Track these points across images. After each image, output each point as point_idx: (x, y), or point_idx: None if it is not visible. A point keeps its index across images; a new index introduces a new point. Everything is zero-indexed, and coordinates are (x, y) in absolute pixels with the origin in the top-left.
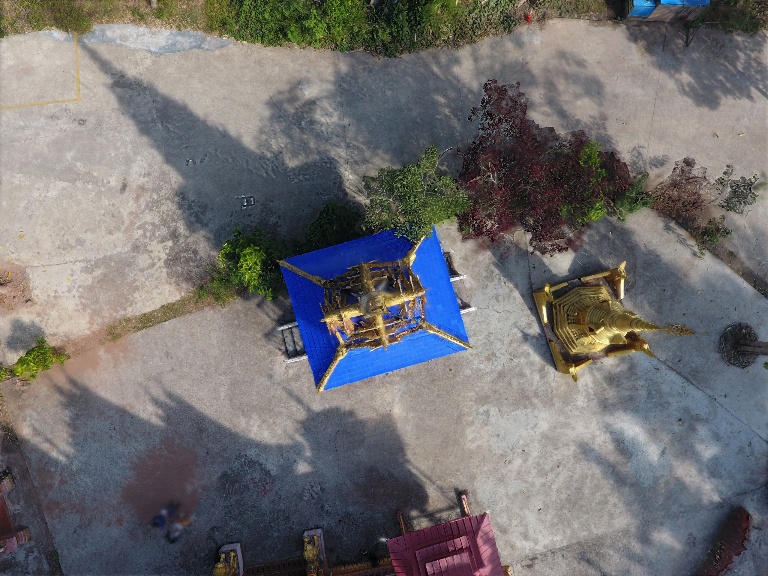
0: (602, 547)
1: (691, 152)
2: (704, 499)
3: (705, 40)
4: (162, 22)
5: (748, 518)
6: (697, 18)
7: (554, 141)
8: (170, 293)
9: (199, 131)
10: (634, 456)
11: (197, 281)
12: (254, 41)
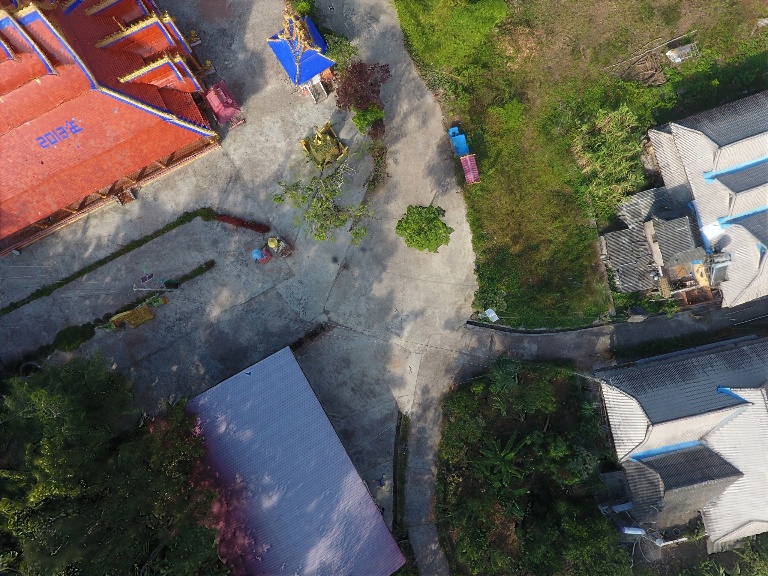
0: (239, 181)
1: (403, 173)
2: (269, 215)
3: (449, 166)
4: None
5: (267, 229)
6: None
7: (375, 94)
8: None
9: None
10: None
11: None
12: None
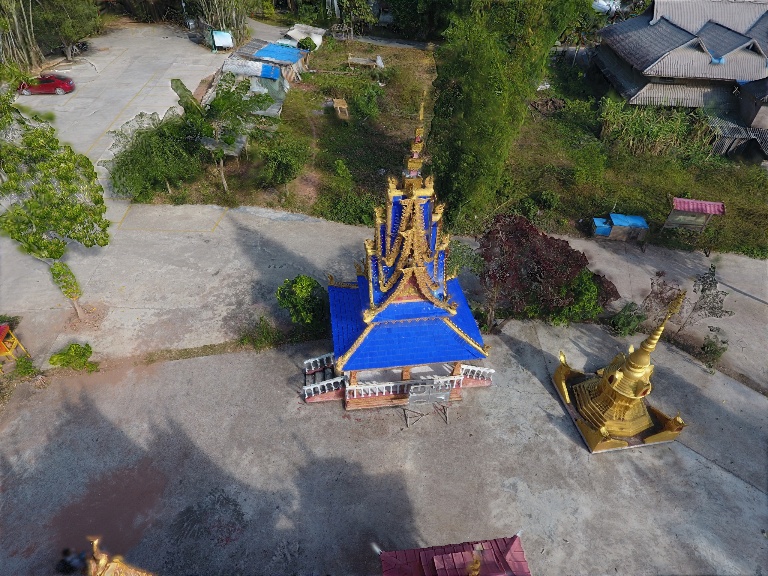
0: None
1: None
2: None
3: (656, 251)
4: (283, 209)
5: None
6: (645, 240)
7: None
8: (217, 338)
9: (285, 253)
10: (719, 572)
11: (244, 333)
12: (339, 221)
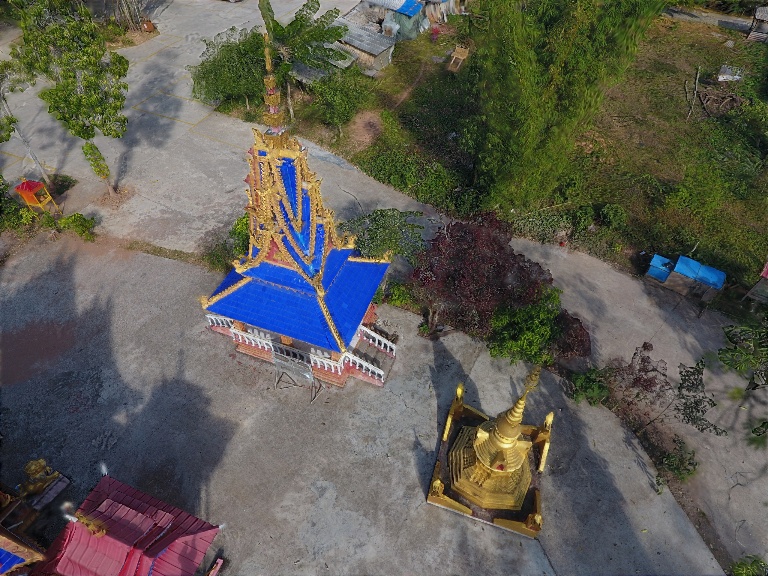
0: None
1: None
2: None
3: (718, 322)
4: (330, 149)
5: None
6: (712, 303)
7: (520, 263)
8: (189, 247)
9: None
10: None
11: None
12: (370, 175)
